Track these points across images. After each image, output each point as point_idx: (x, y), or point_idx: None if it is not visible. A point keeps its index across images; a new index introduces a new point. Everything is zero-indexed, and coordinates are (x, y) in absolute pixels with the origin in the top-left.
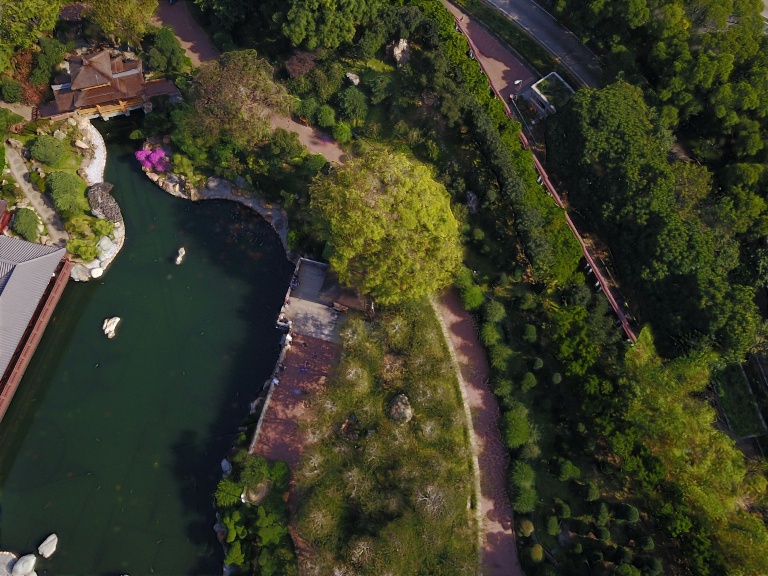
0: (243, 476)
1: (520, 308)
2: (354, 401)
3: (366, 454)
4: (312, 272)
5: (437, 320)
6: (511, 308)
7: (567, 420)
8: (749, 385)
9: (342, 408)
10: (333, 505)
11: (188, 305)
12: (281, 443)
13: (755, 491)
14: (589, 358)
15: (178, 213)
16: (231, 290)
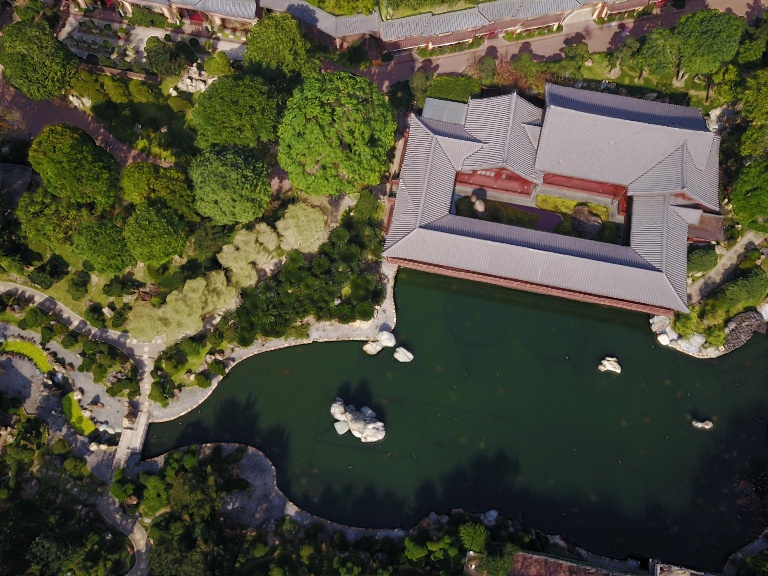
0: (496, 560)
1: None
2: None
3: None
4: None
5: None
6: None
7: None
8: None
9: None
10: None
11: (648, 440)
12: None
13: None
14: None
15: (751, 410)
16: (675, 487)
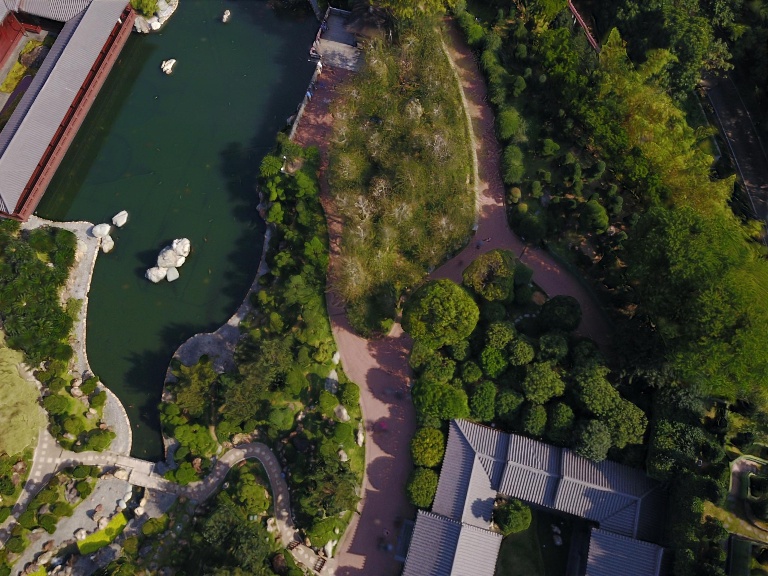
0: (284, 144)
1: (514, 35)
2: (375, 93)
3: (385, 124)
4: (339, 21)
5: (444, 53)
6: (506, 43)
7: (551, 119)
8: (707, 120)
9: (365, 97)
10: (357, 163)
11: (233, 55)
12: (313, 141)
13: (703, 164)
14: (569, 60)
15: None
16: (269, 44)
